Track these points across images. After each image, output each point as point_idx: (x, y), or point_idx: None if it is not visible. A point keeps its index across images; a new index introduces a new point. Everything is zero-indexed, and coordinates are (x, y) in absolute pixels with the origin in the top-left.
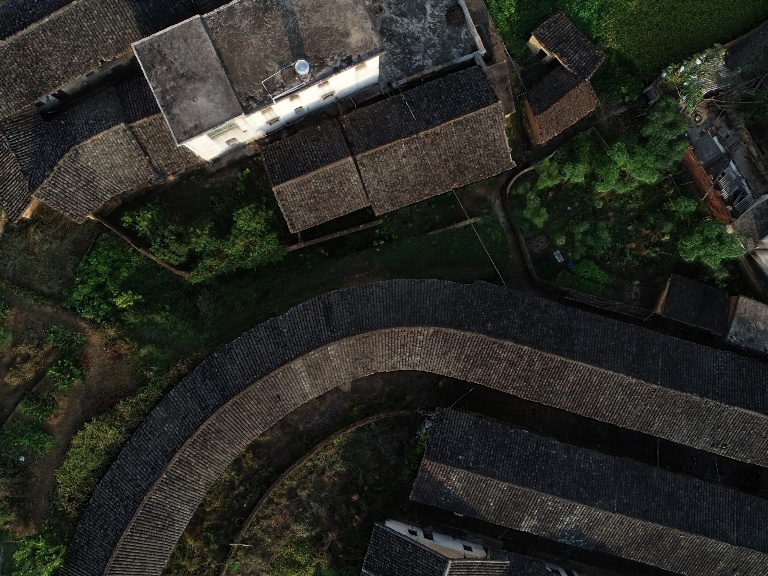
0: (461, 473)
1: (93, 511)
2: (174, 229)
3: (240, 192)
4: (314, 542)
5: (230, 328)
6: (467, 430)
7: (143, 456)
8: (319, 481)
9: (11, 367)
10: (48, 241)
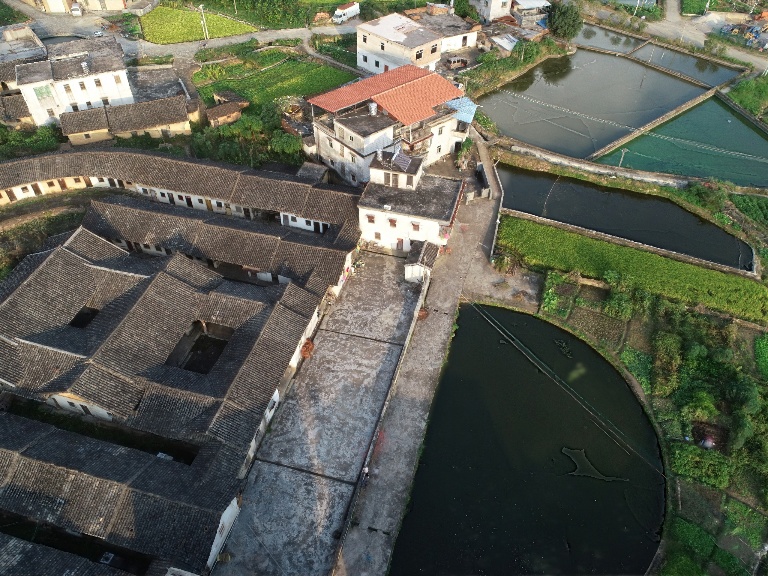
0: (112, 208)
1: None
2: (1, 124)
3: None
4: None
5: None
6: None
7: None
8: None
9: None
10: None
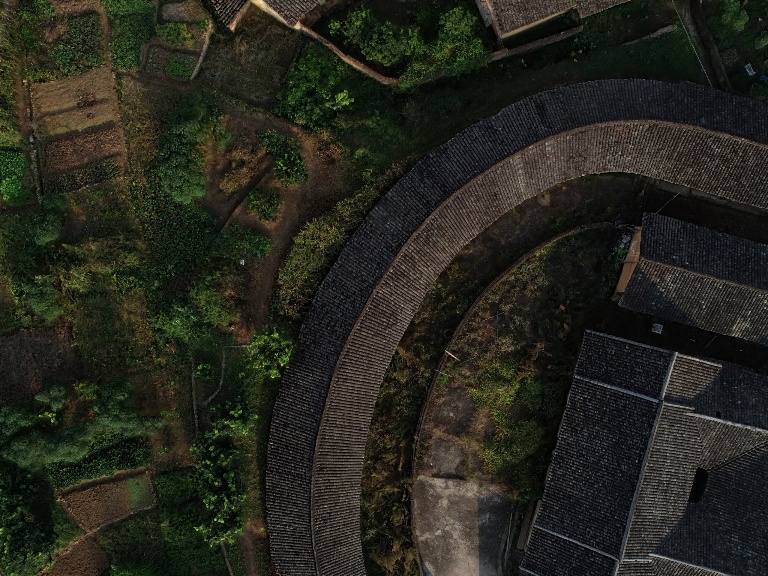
0: (676, 272)
1: (317, 311)
2: (390, 26)
3: (436, 5)
4: (518, 357)
5: (436, 136)
6: (677, 233)
7: (366, 254)
8: (521, 296)
9: (226, 173)
10: (254, 52)
